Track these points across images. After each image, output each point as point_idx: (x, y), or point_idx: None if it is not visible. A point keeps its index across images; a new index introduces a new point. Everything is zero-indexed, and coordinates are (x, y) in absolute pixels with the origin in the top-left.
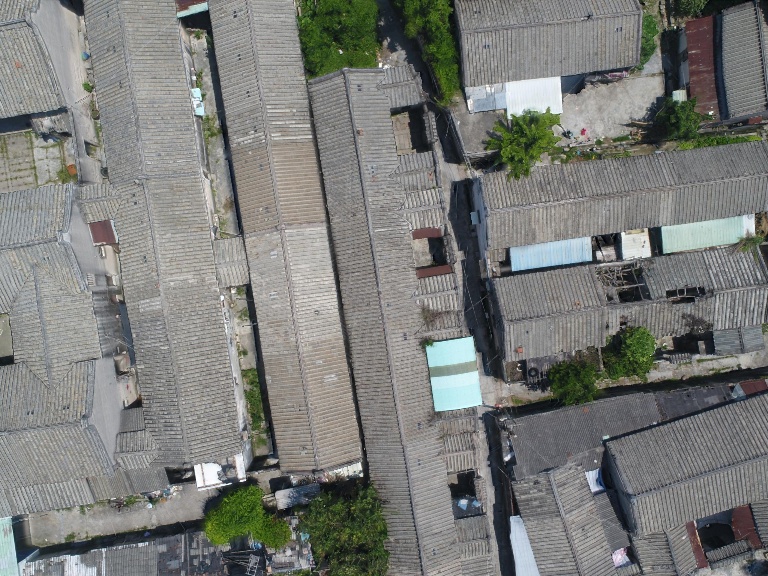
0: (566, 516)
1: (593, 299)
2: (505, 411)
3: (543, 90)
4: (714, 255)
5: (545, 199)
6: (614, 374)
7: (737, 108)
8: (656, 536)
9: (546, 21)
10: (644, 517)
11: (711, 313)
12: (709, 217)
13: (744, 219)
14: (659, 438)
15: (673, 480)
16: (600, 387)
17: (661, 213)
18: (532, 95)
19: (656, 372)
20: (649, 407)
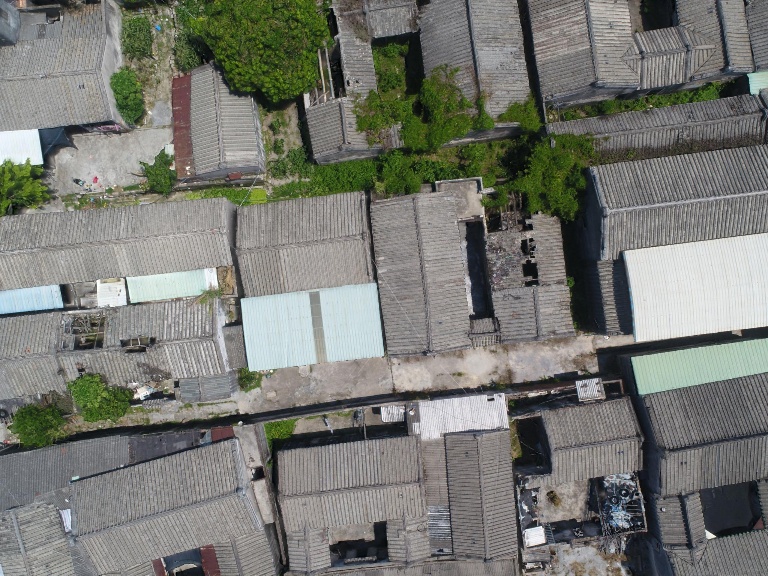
0: (27, 553)
1: (43, 346)
2: (4, 448)
3: (22, 142)
4: (175, 306)
5: (3, 248)
6: (87, 417)
7: (200, 165)
8: (116, 575)
9: (7, 77)
10: (94, 557)
11: (165, 362)
12: (169, 270)
13: (206, 272)
14: (116, 481)
15: (116, 523)
16: (104, 427)
17: (120, 265)
18: (12, 146)
19: (158, 414)
20: (121, 450)
